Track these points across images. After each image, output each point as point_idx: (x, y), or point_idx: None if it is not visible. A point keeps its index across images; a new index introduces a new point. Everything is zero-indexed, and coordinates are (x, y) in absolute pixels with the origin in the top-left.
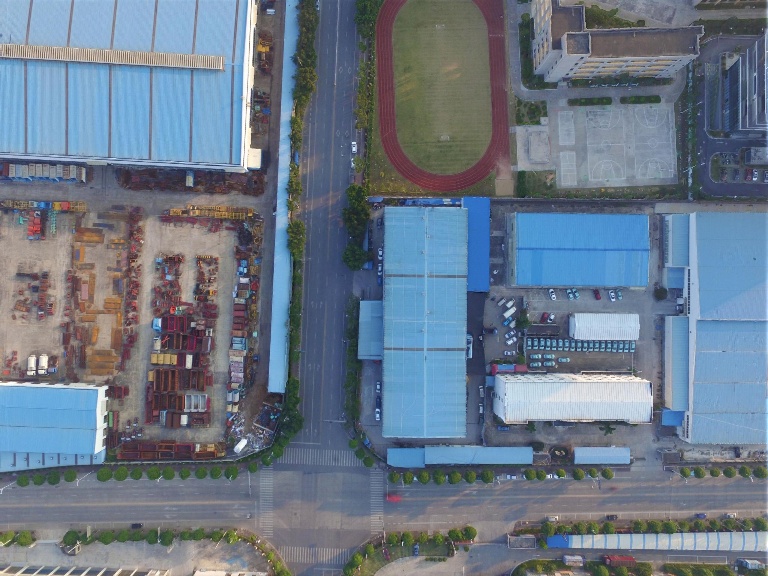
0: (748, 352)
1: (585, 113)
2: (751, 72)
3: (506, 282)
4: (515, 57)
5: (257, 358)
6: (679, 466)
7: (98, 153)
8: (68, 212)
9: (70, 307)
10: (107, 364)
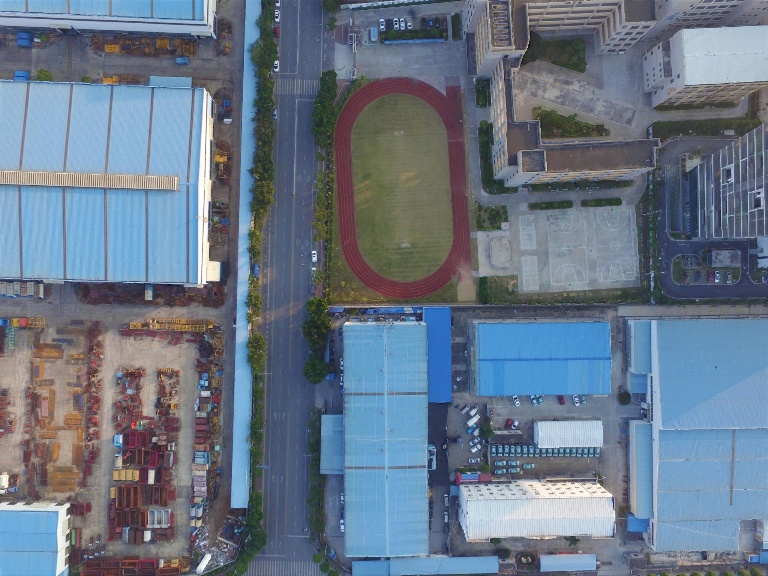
0: (711, 460)
1: (546, 217)
2: (708, 183)
3: (469, 389)
4: (475, 162)
5: (220, 471)
6: (646, 569)
7: (53, 275)
8: (26, 328)
9: (30, 424)
10: (69, 481)
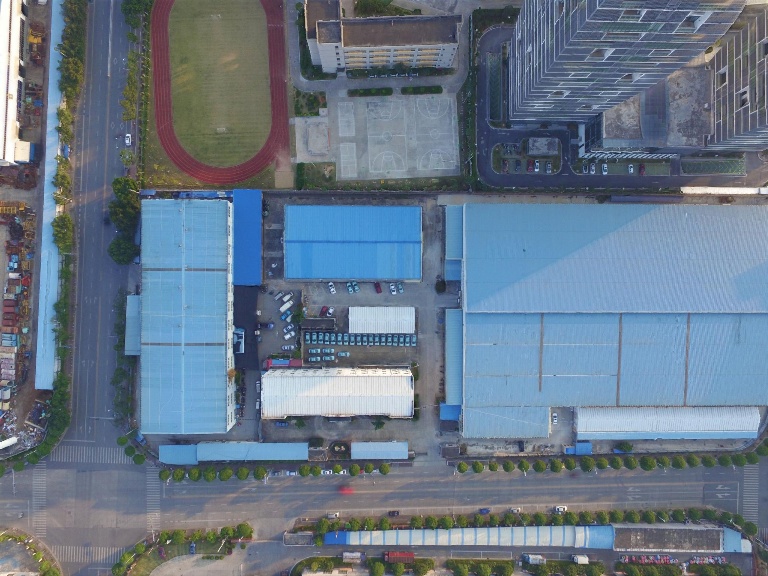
0: (519, 345)
1: (365, 104)
2: (513, 61)
3: None
4: (294, 47)
5: (28, 355)
6: (462, 461)
7: None
8: None
9: None
10: None
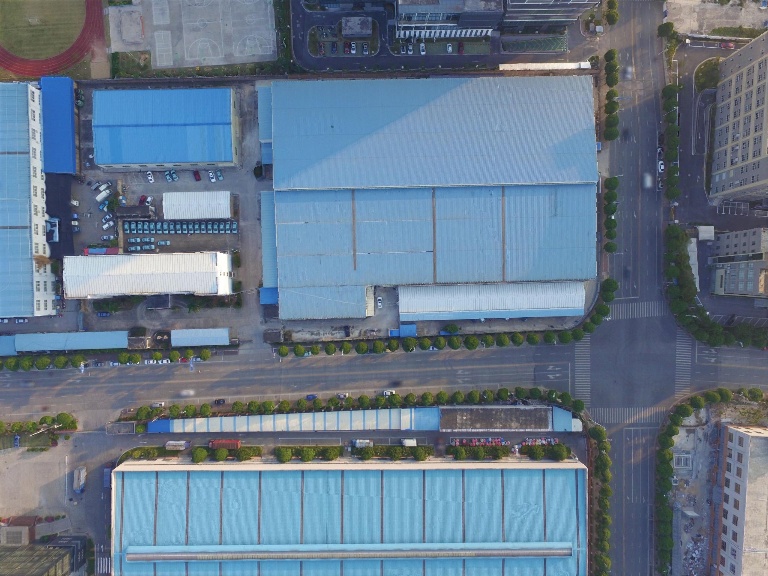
0: (331, 223)
1: None
2: None
3: None
4: None
5: None
6: (288, 347)
7: None
8: None
9: None
10: None
